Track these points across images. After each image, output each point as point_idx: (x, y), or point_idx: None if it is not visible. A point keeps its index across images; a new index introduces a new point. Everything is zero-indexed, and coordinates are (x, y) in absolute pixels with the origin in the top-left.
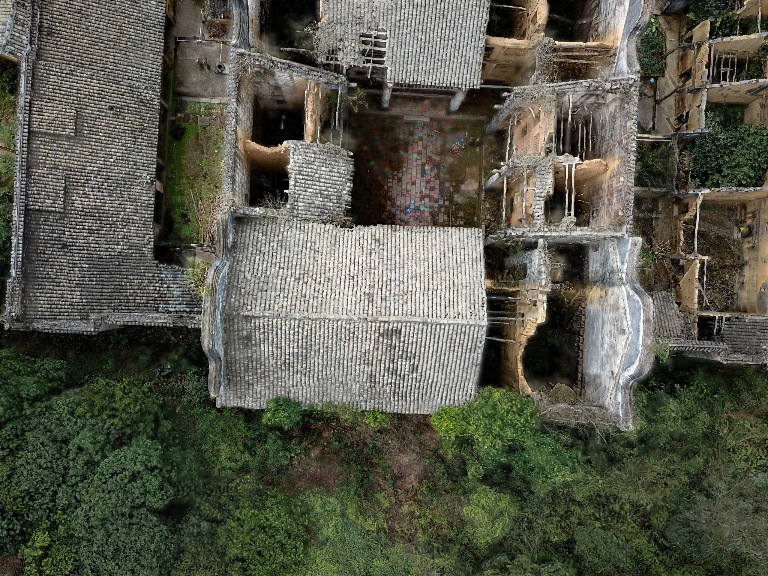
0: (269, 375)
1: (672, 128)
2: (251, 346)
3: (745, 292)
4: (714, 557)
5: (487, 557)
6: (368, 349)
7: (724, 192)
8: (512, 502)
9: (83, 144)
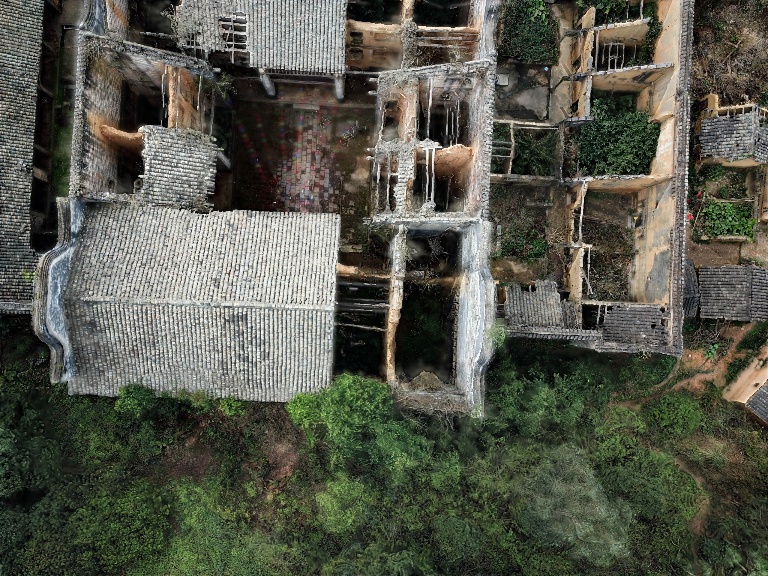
0: (119, 362)
1: (566, 117)
2: (96, 332)
3: (636, 282)
4: (578, 547)
5: (344, 547)
6: (216, 335)
7: (608, 180)
8: (373, 491)
9: None
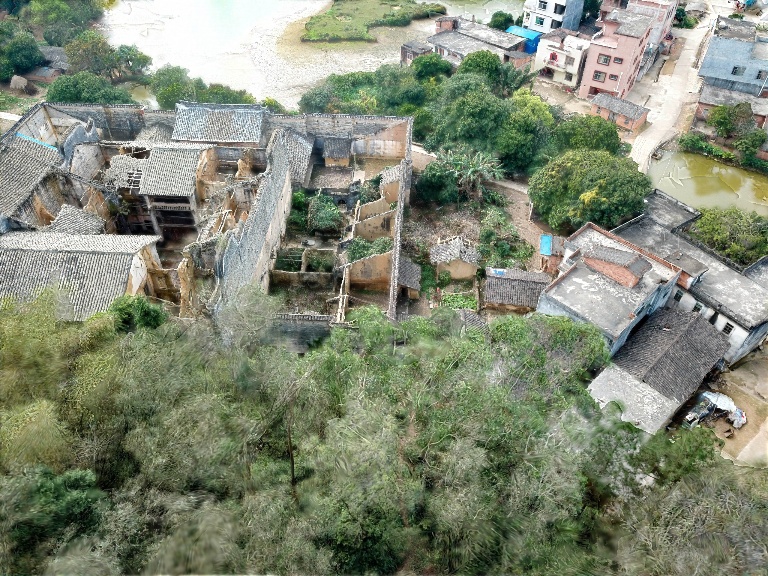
0: None
1: None
2: None
3: None
4: None
5: None
6: None
7: (359, 263)
8: None
9: None
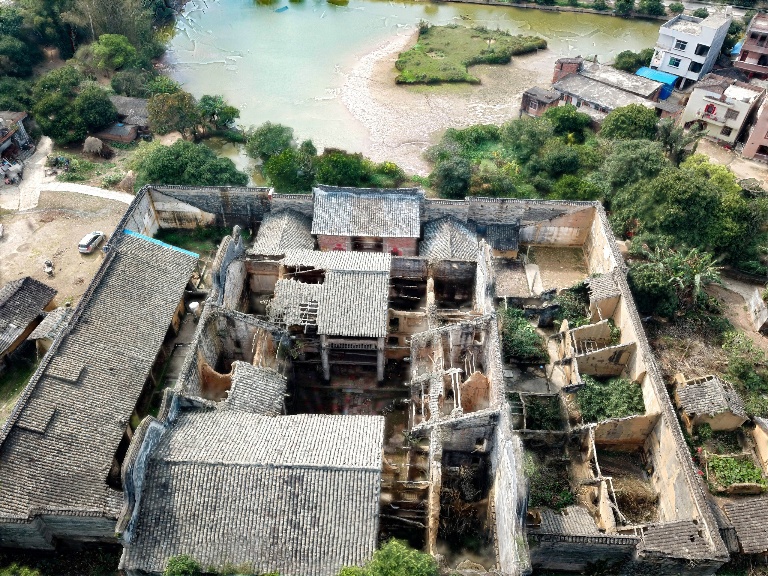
0: (177, 530)
1: None
2: (166, 495)
3: None
4: None
5: None
6: (273, 498)
7: (609, 424)
8: None
9: (80, 389)
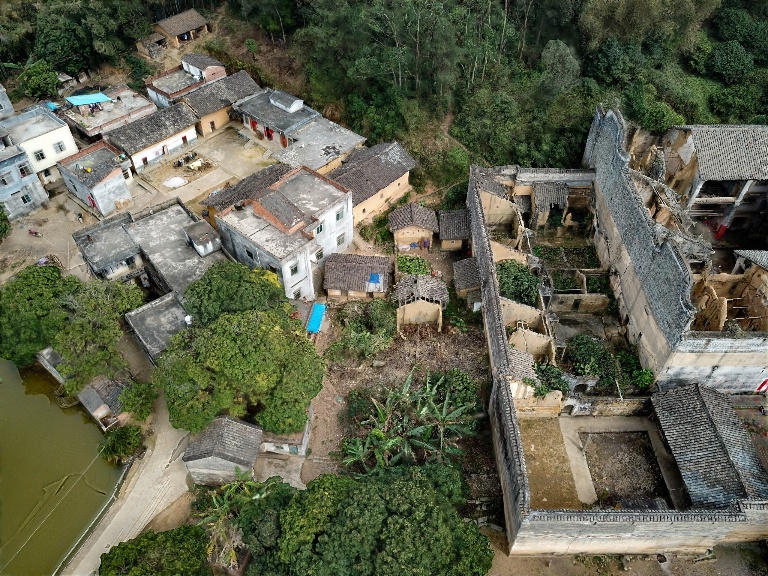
0: None
1: None
2: None
3: None
4: None
5: None
6: None
7: None
8: None
9: None
